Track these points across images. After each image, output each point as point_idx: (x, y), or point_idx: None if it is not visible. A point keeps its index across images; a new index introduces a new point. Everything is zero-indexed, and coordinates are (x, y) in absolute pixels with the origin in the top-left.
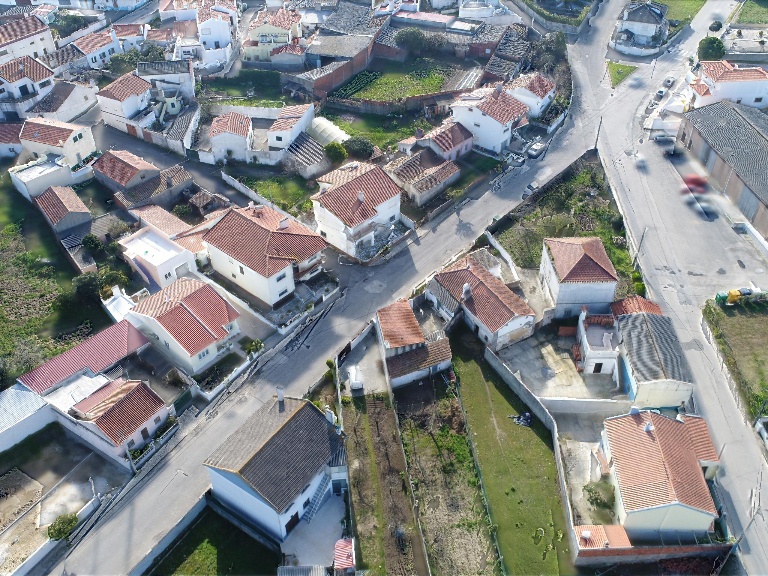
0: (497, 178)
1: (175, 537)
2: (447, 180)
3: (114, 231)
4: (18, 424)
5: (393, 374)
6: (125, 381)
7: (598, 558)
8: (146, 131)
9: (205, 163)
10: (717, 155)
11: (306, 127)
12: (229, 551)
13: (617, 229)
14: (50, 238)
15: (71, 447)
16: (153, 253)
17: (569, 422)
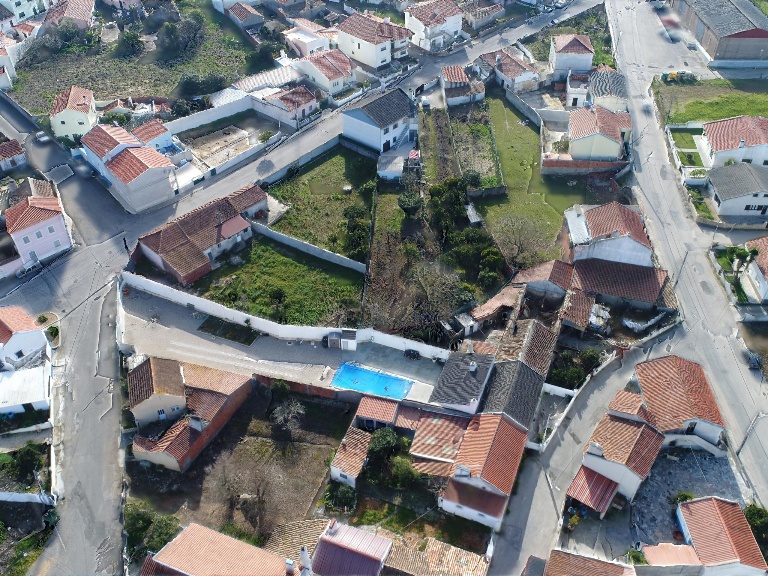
0: (531, 18)
1: (322, 152)
2: (495, 15)
3: (278, 28)
4: (235, 102)
5: (448, 96)
6: (292, 89)
7: (554, 169)
8: None
9: (333, 1)
10: (686, 4)
11: None
12: (351, 159)
13: (607, 43)
14: (238, 31)
15: (261, 120)
16: (303, 39)
17: (552, 124)
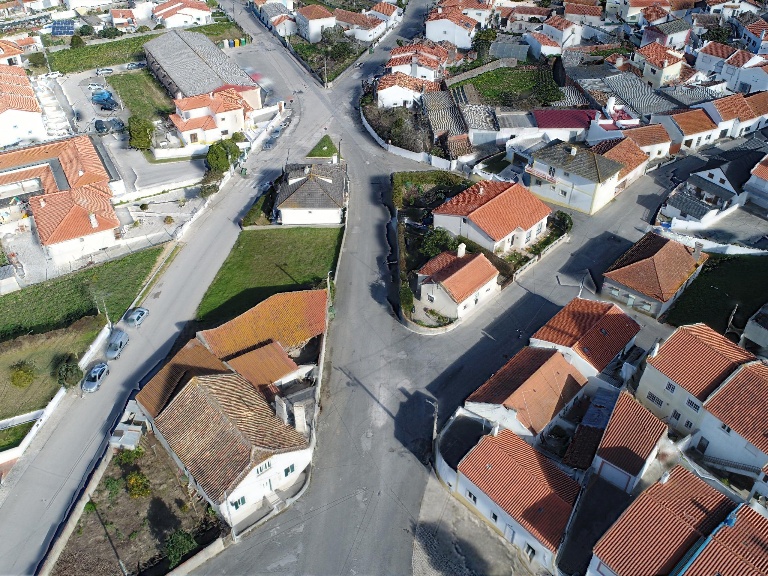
0: None
1: None
2: None
3: None
4: None
5: None
6: None
7: None
8: (618, 27)
9: None
10: None
11: (533, 48)
12: None
13: None
14: None
15: None
16: None
17: None
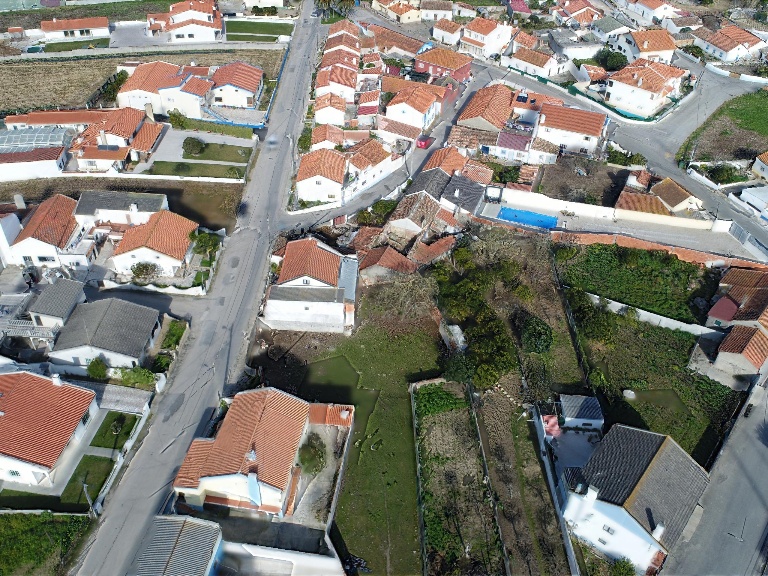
0: None
1: None
2: None
3: None
4: None
5: None
6: None
7: None
8: None
9: None
10: None
11: None
12: None
13: None
14: None
15: None
16: None
17: (303, 550)
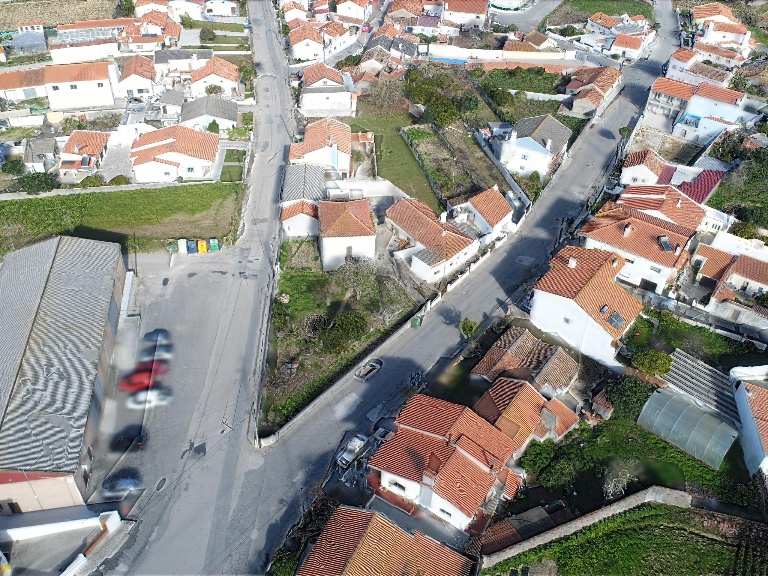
0: (417, 392)
1: None
2: None
3: None
4: None
5: None
6: None
7: None
8: None
9: None
10: None
11: (743, 433)
12: None
13: None
14: None
15: None
16: (741, 248)
17: None
